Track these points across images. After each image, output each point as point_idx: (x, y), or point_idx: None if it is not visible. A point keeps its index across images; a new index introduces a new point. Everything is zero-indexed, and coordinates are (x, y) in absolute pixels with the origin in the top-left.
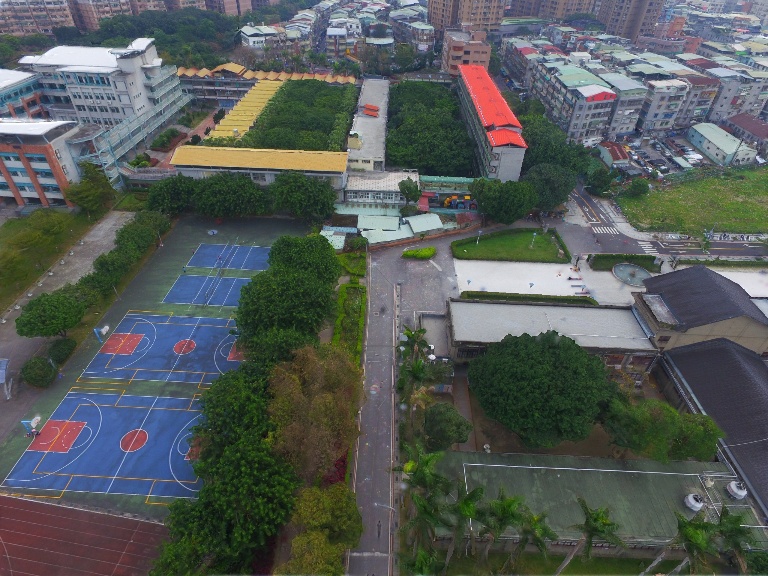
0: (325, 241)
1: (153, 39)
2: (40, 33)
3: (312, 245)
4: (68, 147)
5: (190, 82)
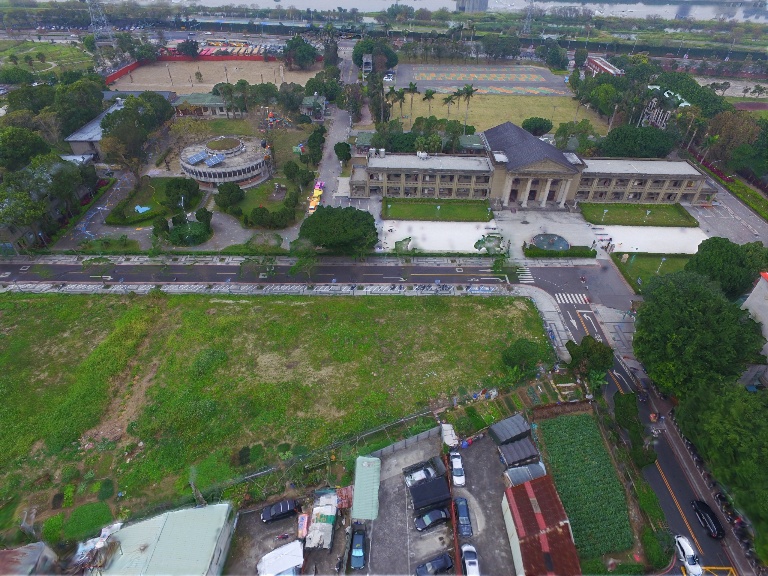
0: None
1: None
2: None
3: None
4: None
5: None
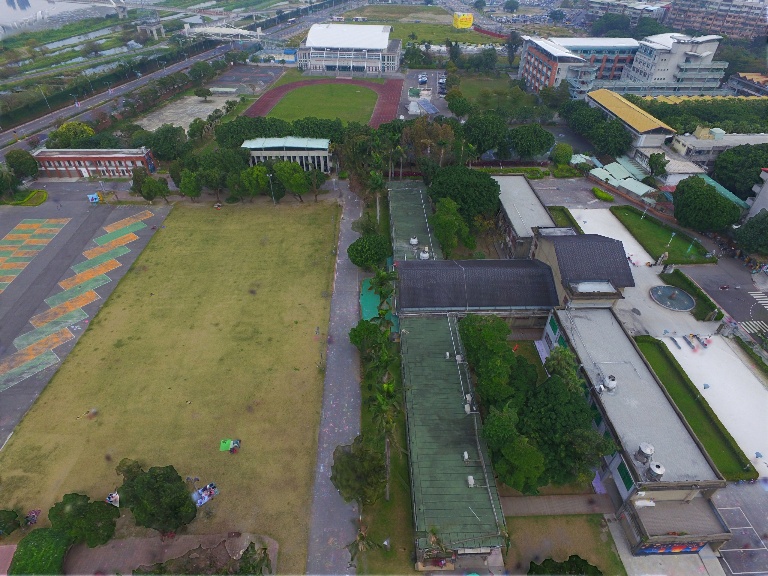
0: (549, 137)
1: (721, 37)
2: (748, 38)
3: (532, 128)
4: (568, 70)
5: (746, 84)
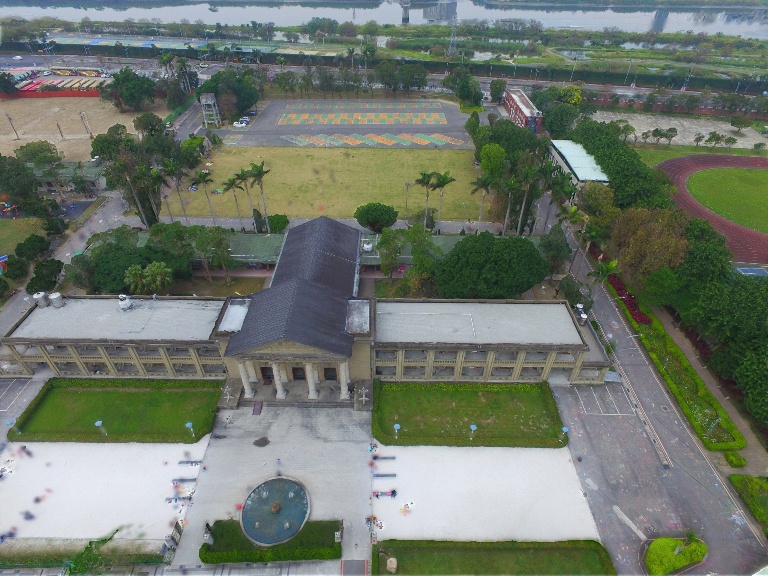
0: None
1: None
2: None
3: None
4: None
5: None
